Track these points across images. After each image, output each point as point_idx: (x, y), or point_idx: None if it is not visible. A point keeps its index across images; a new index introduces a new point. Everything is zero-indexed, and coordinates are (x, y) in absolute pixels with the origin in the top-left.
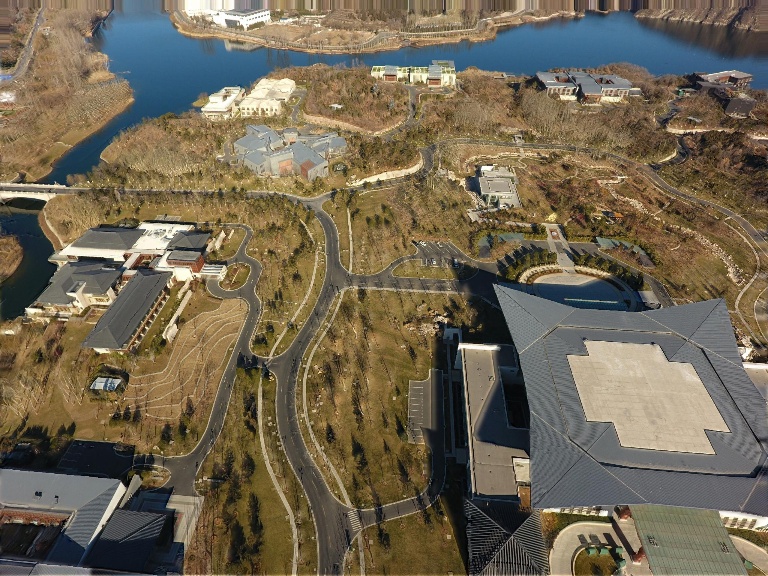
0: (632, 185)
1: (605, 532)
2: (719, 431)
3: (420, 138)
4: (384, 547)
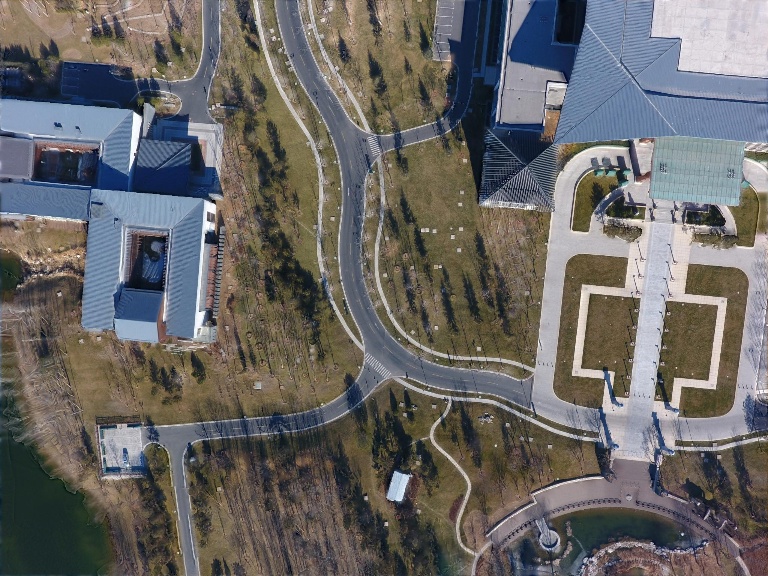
0: None
1: (619, 155)
2: None
3: None
4: (402, 170)
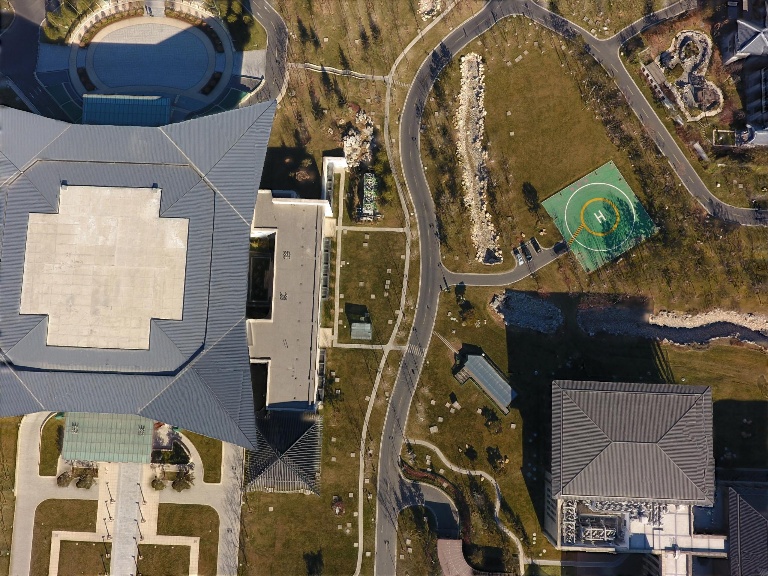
0: None
1: None
2: (168, 319)
3: None
4: None
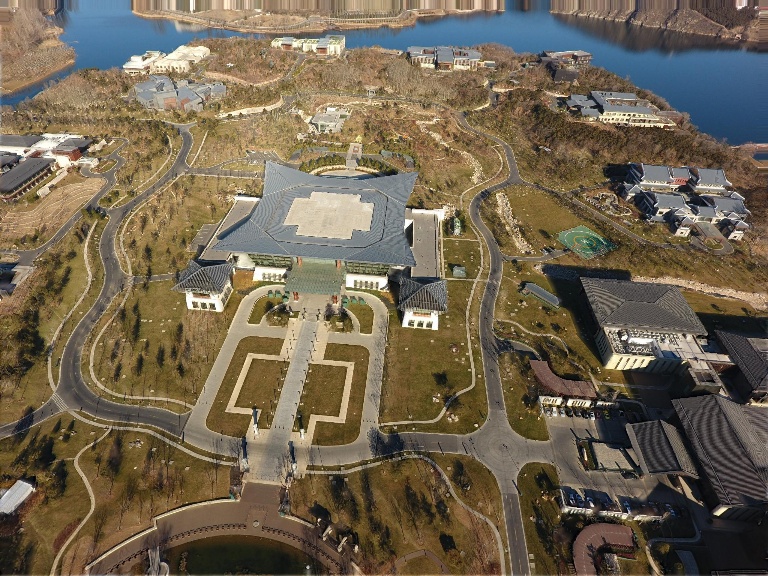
0: (441, 124)
1: None
2: (362, 231)
3: (290, 89)
4: None
